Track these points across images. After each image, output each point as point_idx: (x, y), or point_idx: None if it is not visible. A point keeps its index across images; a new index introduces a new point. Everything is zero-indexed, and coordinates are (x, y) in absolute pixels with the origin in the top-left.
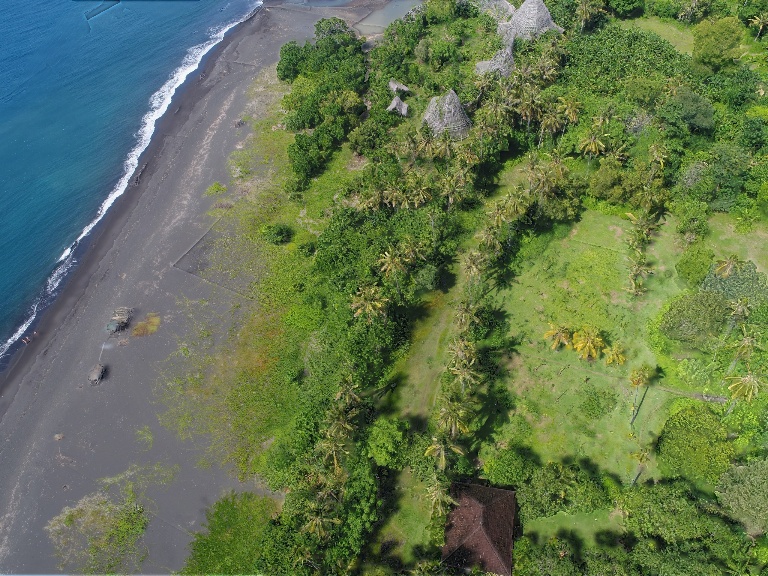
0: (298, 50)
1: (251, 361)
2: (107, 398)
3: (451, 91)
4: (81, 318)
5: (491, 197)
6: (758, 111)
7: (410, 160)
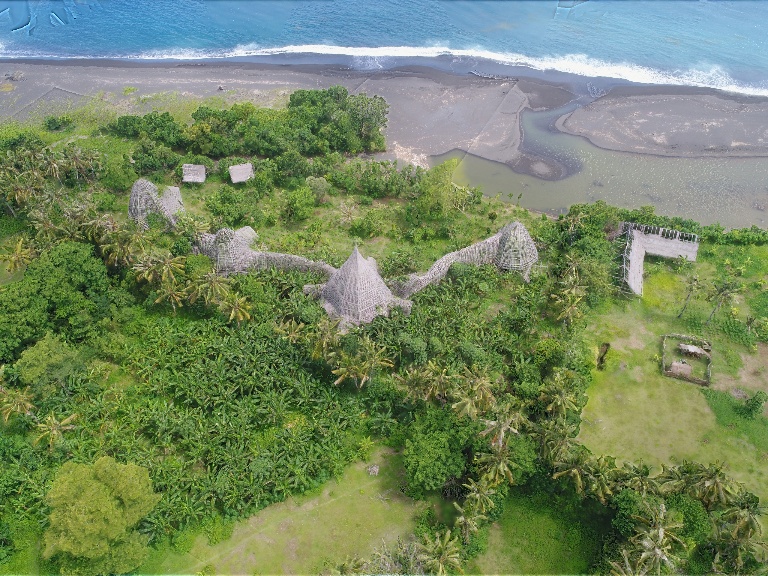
0: (327, 96)
1: None
2: None
3: (138, 180)
4: (40, 68)
5: None
6: None
7: (116, 191)
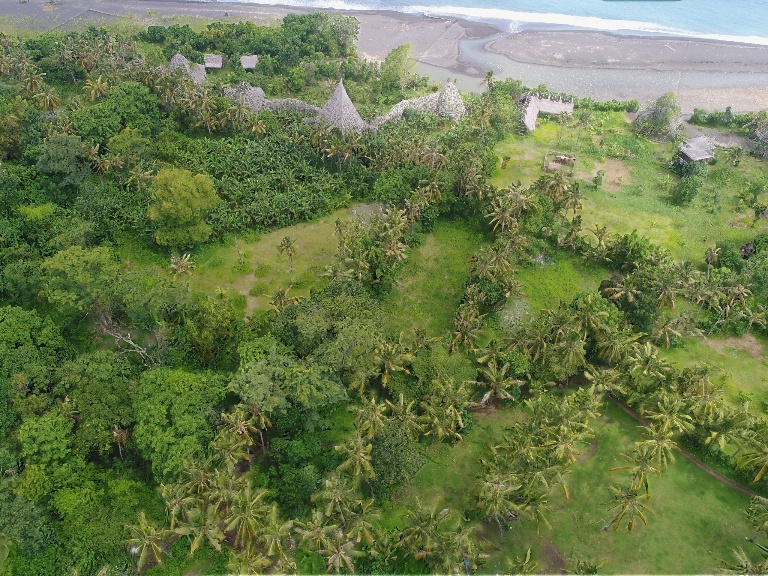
0: (313, 17)
1: (4, 33)
2: (9, 5)
3: (176, 54)
4: None
5: (83, 101)
6: (43, 207)
7: None
